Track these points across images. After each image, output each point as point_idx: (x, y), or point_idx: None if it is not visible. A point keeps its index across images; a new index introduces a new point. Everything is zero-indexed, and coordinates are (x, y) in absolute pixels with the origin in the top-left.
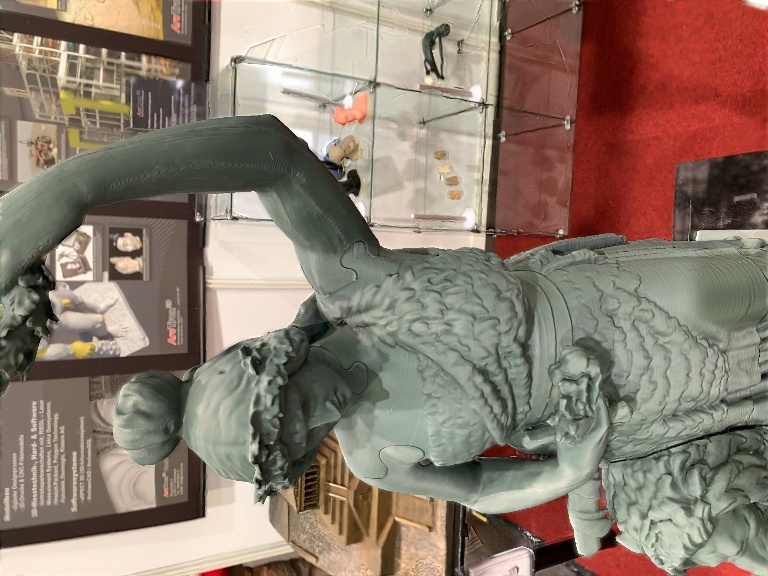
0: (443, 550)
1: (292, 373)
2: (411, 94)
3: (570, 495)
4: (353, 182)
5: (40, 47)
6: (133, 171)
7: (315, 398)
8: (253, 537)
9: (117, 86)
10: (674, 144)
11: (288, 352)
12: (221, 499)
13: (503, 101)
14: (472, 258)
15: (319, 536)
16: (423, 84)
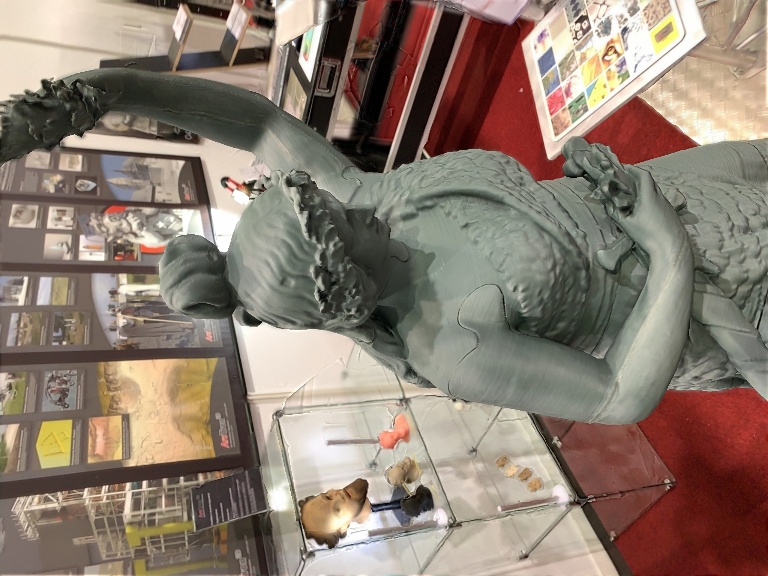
0: None
1: None
2: (452, 436)
3: (721, 342)
4: (422, 491)
5: (107, 494)
6: None
7: None
8: None
9: (179, 507)
10: None
11: None
12: None
13: None
14: None
15: None
16: None
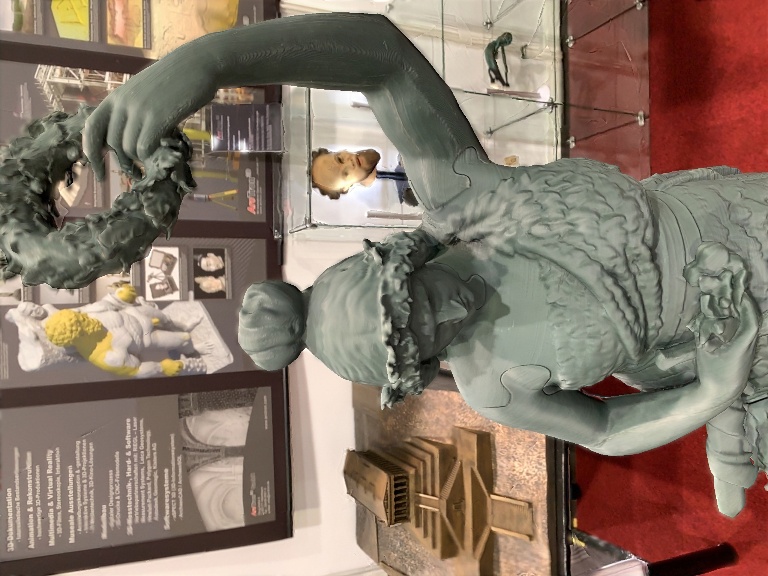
0: (547, 560)
1: (415, 269)
2: (476, 106)
3: (710, 433)
4: None
5: None
6: (260, 46)
7: (439, 295)
8: (341, 561)
9: (198, 115)
10: (762, 124)
11: (410, 246)
12: (307, 520)
13: (570, 107)
14: (588, 162)
15: (411, 554)
16: (490, 88)
